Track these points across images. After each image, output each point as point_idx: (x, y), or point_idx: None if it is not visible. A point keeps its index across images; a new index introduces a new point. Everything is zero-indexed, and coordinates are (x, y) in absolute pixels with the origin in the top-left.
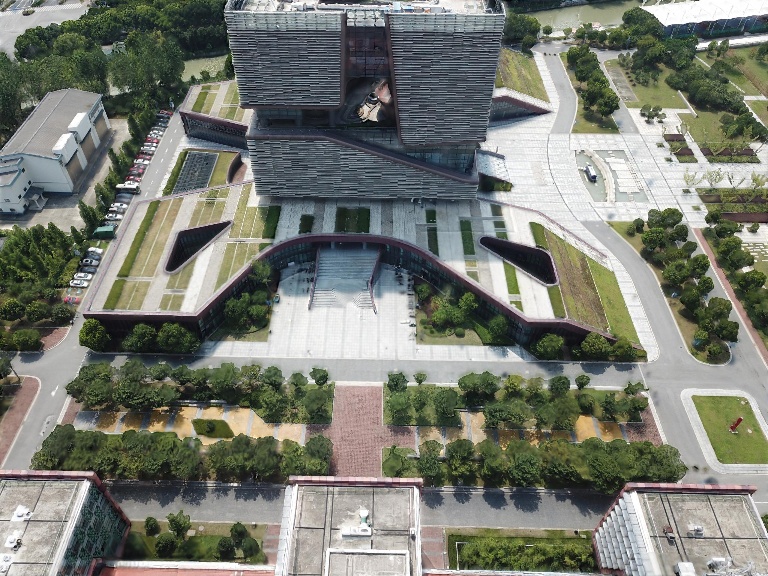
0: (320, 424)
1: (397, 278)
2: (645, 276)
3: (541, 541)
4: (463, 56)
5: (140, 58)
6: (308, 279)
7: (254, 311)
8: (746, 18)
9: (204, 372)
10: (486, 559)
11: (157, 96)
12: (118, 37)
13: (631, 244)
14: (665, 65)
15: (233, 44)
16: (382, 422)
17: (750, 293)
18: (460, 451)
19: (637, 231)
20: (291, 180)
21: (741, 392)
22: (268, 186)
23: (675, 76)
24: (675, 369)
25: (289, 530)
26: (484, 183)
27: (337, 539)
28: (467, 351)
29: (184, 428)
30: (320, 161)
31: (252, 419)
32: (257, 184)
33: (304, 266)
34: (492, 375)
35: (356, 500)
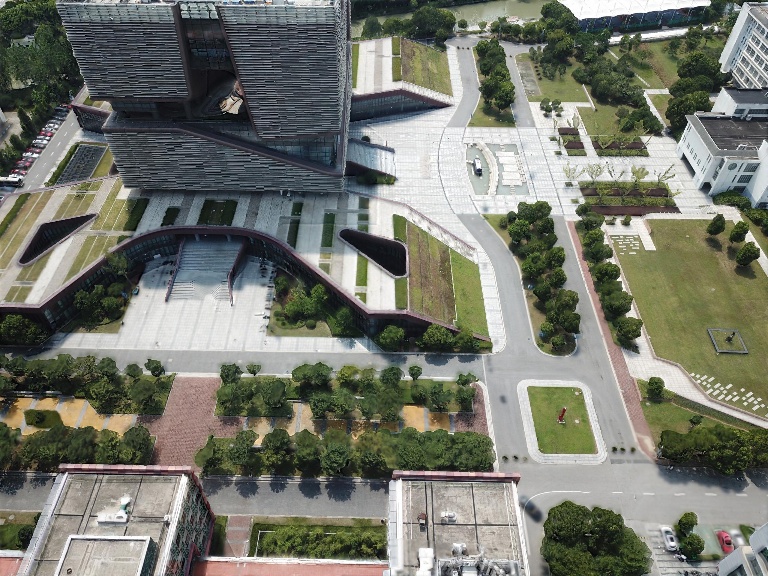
0: (151, 415)
1: (260, 270)
2: (509, 268)
3: (344, 529)
4: (301, 48)
5: (39, 51)
6: (171, 271)
7: (106, 303)
8: (662, 12)
9: (38, 363)
10: (282, 547)
11: (57, 89)
12: (31, 31)
13: (502, 237)
14: (576, 59)
15: (70, 36)
16: (214, 413)
17: (603, 285)
18: (273, 441)
19: (510, 224)
20: (156, 173)
21: (578, 383)
22: (134, 179)
23: (581, 70)
24: (518, 360)
25: (48, 517)
26: (366, 176)
27: (93, 526)
28: (315, 343)
29: (15, 419)
30: (180, 154)
31: (85, 410)
32: (123, 177)
33: (171, 259)
34: (324, 366)
35: (122, 488)
